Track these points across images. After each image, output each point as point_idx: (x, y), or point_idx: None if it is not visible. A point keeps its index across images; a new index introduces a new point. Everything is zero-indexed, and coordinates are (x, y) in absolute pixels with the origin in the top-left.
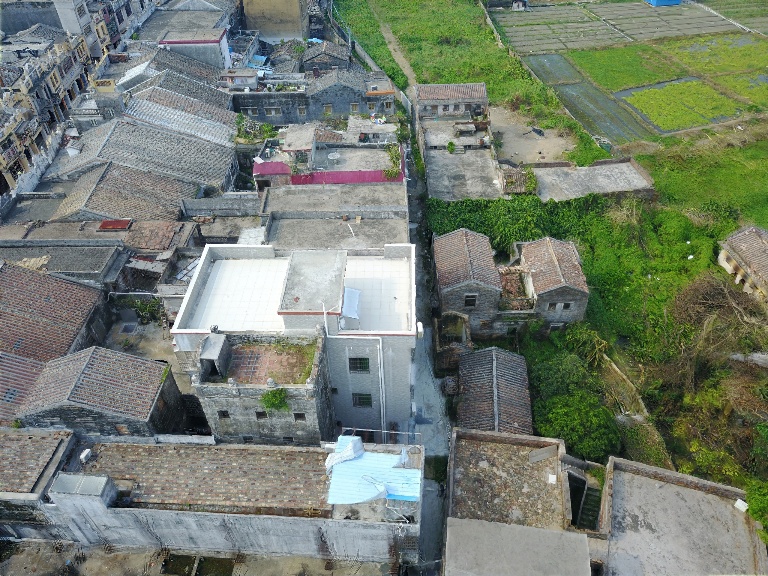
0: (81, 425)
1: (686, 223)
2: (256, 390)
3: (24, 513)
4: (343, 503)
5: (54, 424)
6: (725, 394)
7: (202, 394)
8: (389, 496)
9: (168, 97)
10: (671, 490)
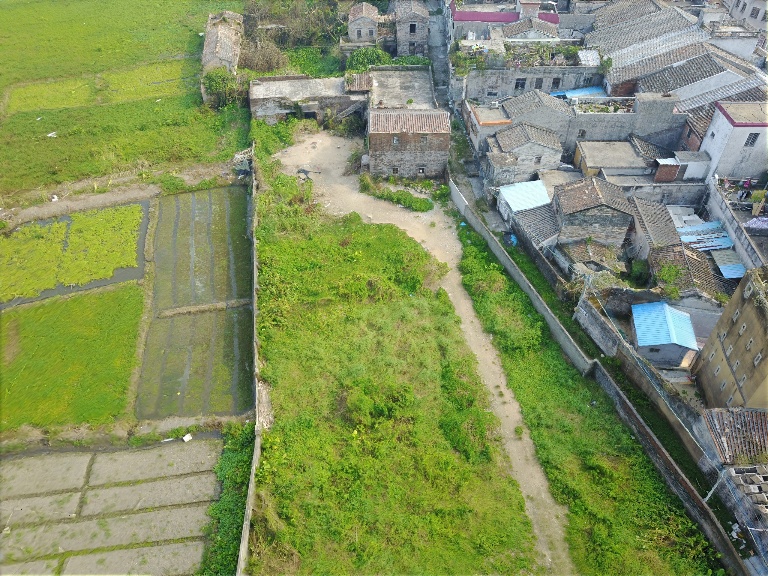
0: None
1: None
2: None
3: None
4: None
5: None
6: None
7: None
8: None
9: (689, 53)
10: None
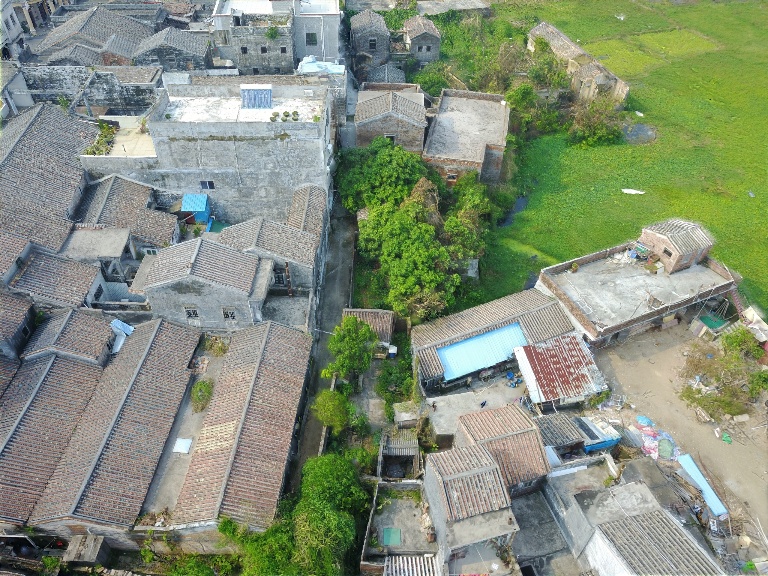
0: (168, 62)
1: (508, 26)
2: (262, 30)
3: (145, 98)
4: (308, 72)
5: (153, 62)
6: (513, 87)
7: (234, 34)
8: (330, 72)
9: None
10: (472, 101)
